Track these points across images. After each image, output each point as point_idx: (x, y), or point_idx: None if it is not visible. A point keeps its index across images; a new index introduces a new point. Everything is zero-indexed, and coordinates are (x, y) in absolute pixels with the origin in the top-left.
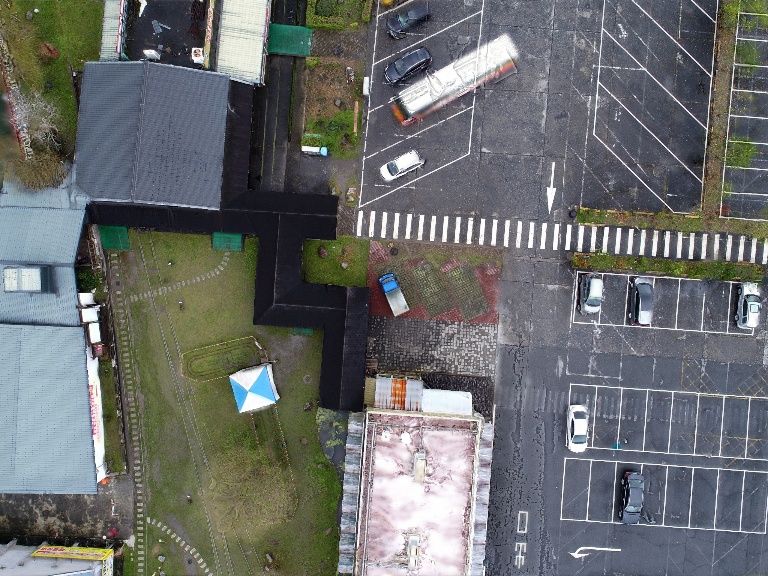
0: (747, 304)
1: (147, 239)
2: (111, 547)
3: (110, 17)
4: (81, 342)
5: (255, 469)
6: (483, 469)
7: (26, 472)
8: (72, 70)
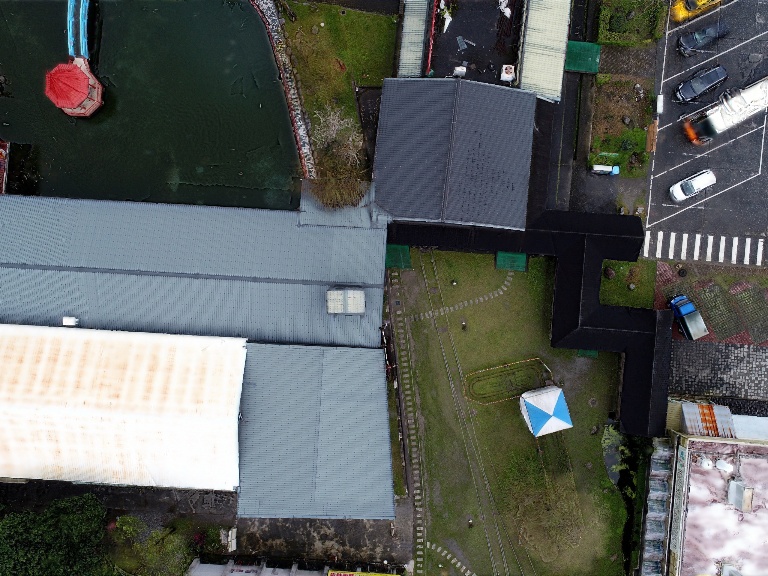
0: None
1: (428, 258)
2: (396, 572)
3: (410, 32)
4: (382, 364)
5: (539, 494)
6: None
7: (326, 497)
8: (355, 85)
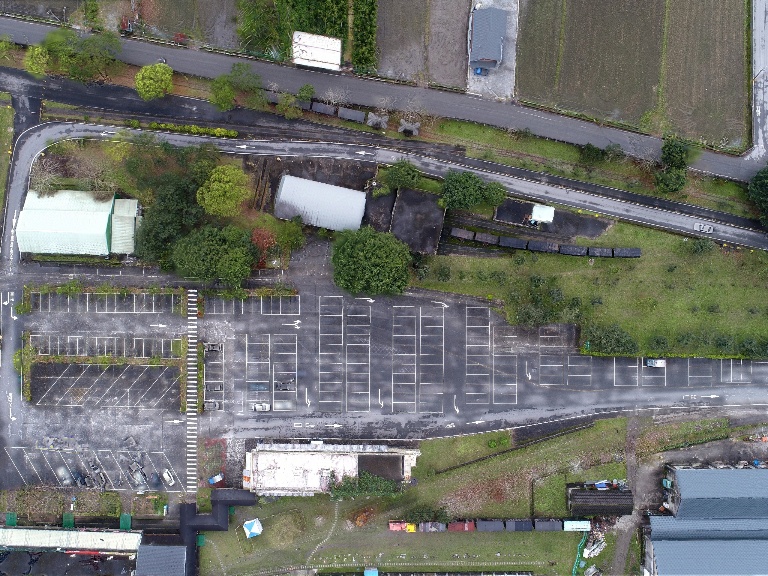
0: None
1: (202, 570)
2: None
3: None
4: None
5: None
6: (273, 447)
7: None
8: None
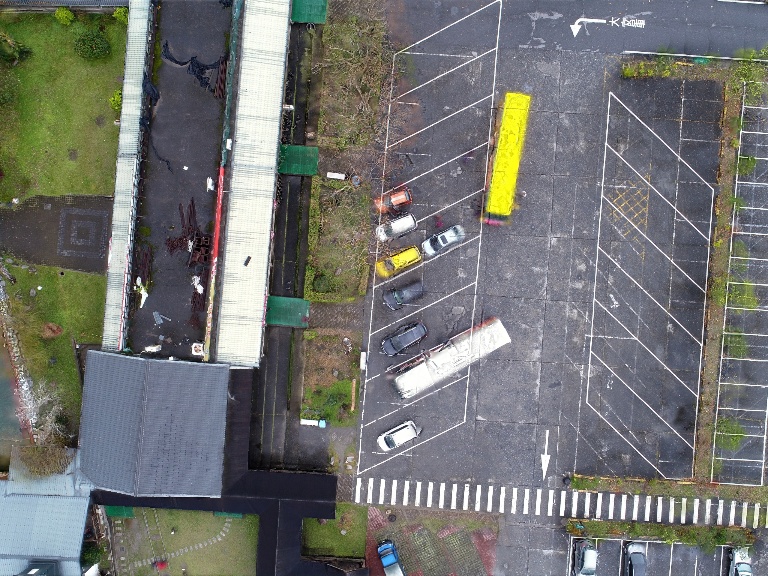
0: (738, 574)
1: None
2: None
3: (112, 305)
4: None
5: None
6: None
7: None
8: (75, 343)
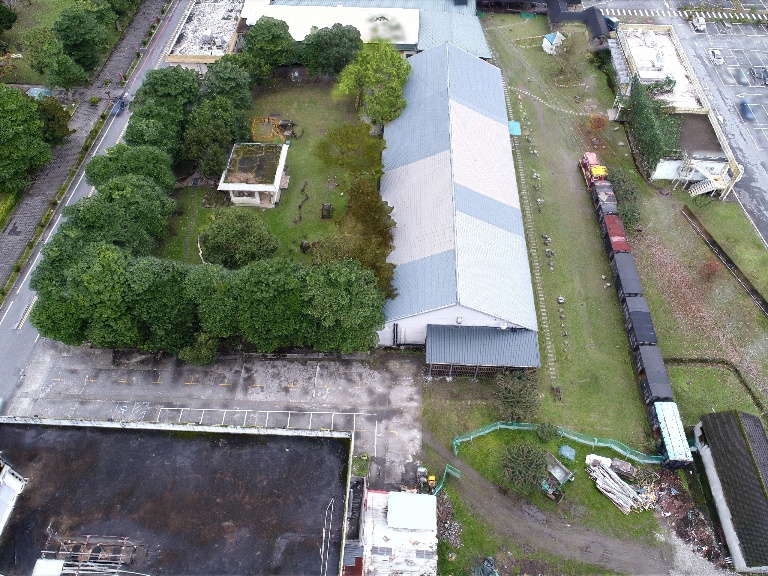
0: None
1: (490, 15)
2: None
3: None
4: None
5: None
6: None
7: None
8: None
